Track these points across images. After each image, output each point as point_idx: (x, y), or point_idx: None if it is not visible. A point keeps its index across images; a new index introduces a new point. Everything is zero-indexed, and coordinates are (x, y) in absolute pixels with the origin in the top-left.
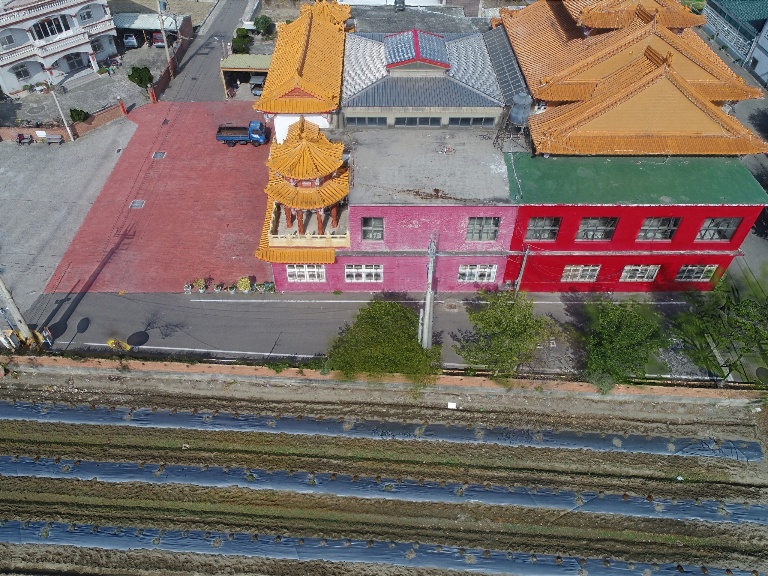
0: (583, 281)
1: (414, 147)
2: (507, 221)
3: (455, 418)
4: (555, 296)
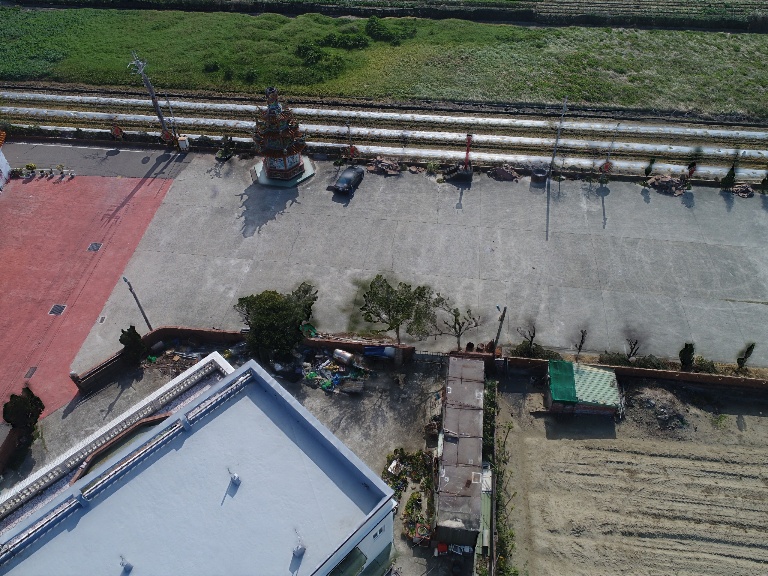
0: None
1: None
2: None
3: None
4: None
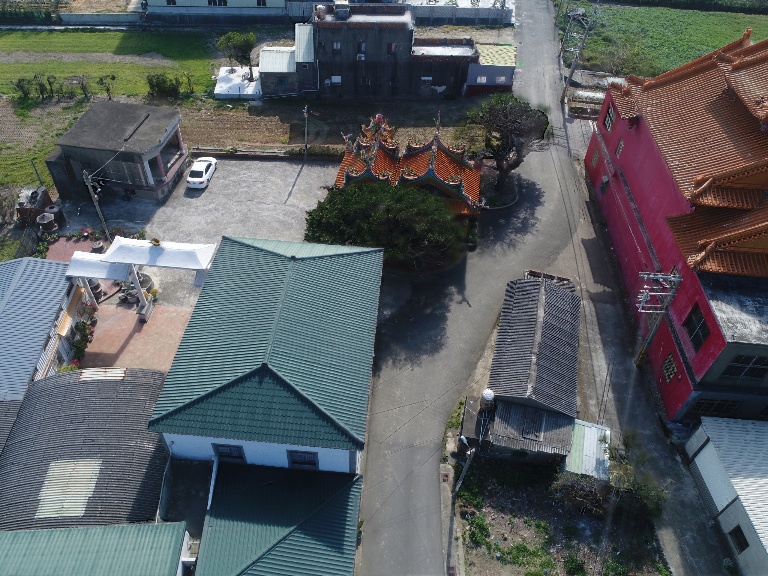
0: None
1: None
2: None
3: None
4: None
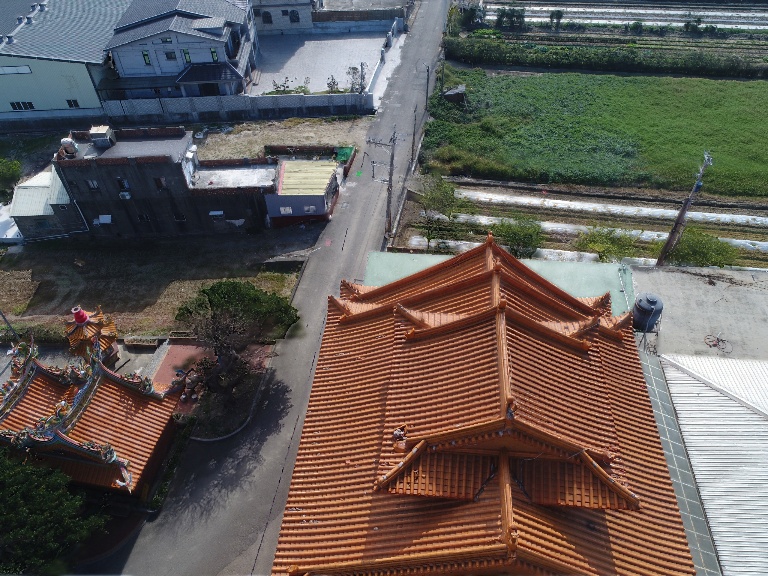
0: None
1: (763, 352)
2: None
3: None
4: None
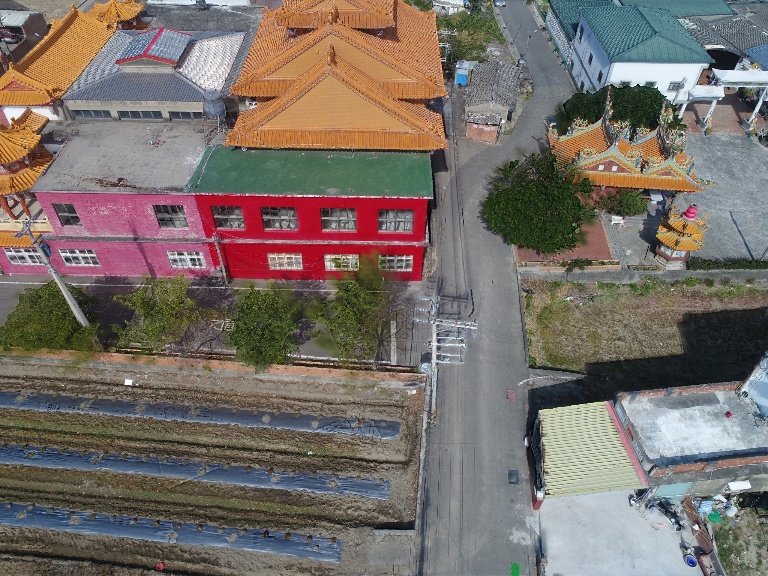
0: (291, 269)
1: (127, 139)
2: (190, 209)
3: (125, 394)
4: (267, 283)
